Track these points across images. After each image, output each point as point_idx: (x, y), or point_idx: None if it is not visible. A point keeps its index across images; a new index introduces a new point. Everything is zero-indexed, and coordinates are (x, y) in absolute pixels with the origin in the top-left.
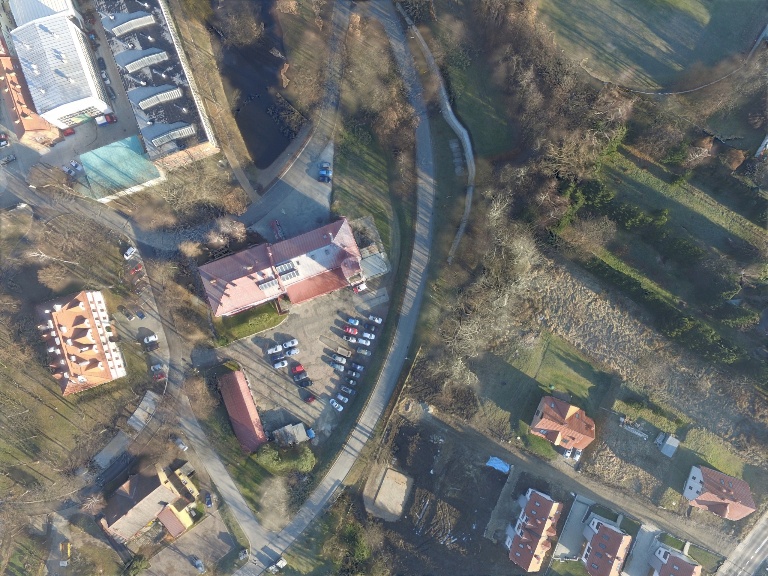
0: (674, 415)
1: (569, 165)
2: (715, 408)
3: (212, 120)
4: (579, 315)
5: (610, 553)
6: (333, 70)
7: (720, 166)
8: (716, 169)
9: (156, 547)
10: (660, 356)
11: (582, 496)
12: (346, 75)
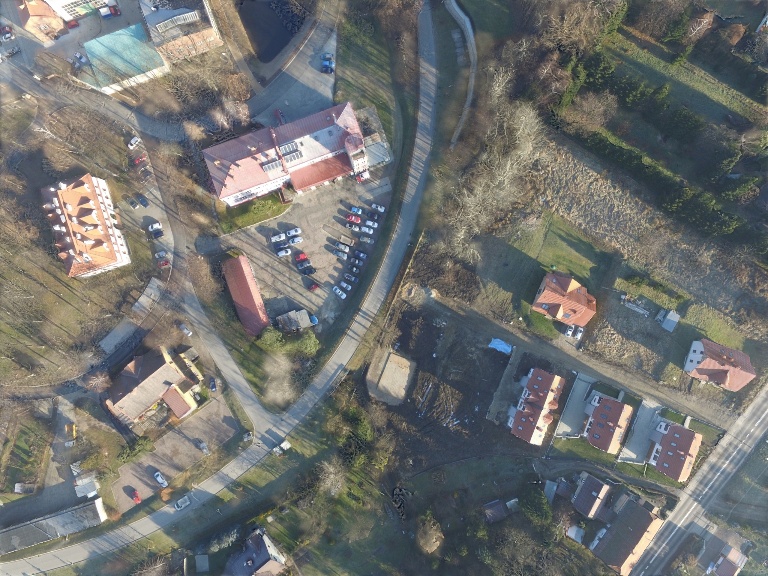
0: (675, 292)
1: (571, 39)
2: (715, 284)
3: (215, 13)
4: (580, 195)
5: (611, 421)
6: None
7: (720, 40)
8: (716, 44)
9: (161, 431)
10: (661, 234)
11: (584, 374)
12: None
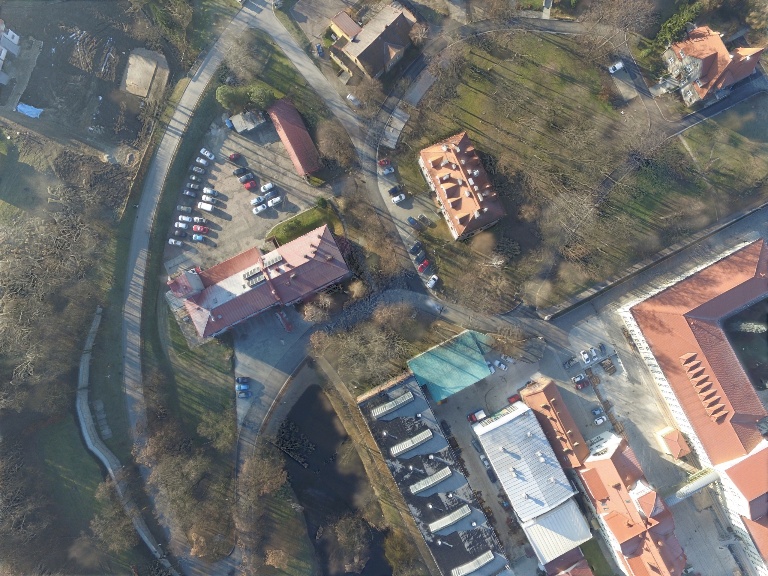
0: None
1: None
2: None
3: None
4: None
5: None
6: (246, 499)
7: None
8: None
9: (365, 3)
10: None
11: None
12: (232, 495)
